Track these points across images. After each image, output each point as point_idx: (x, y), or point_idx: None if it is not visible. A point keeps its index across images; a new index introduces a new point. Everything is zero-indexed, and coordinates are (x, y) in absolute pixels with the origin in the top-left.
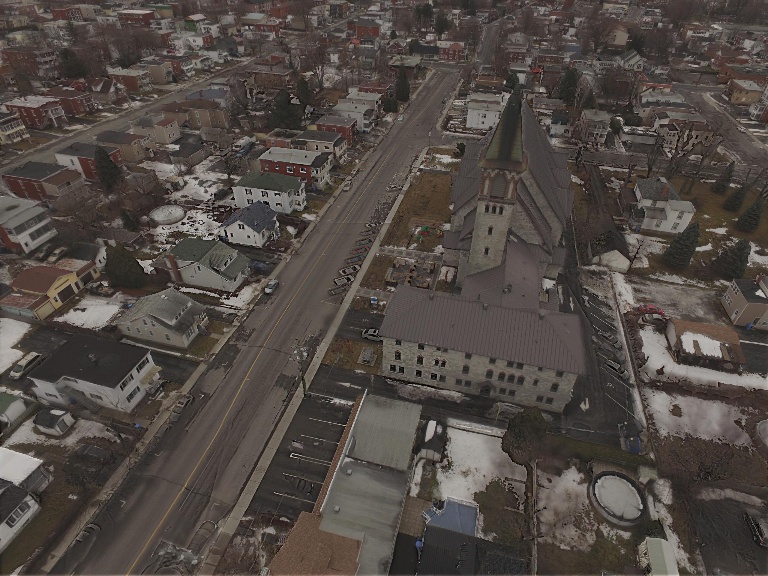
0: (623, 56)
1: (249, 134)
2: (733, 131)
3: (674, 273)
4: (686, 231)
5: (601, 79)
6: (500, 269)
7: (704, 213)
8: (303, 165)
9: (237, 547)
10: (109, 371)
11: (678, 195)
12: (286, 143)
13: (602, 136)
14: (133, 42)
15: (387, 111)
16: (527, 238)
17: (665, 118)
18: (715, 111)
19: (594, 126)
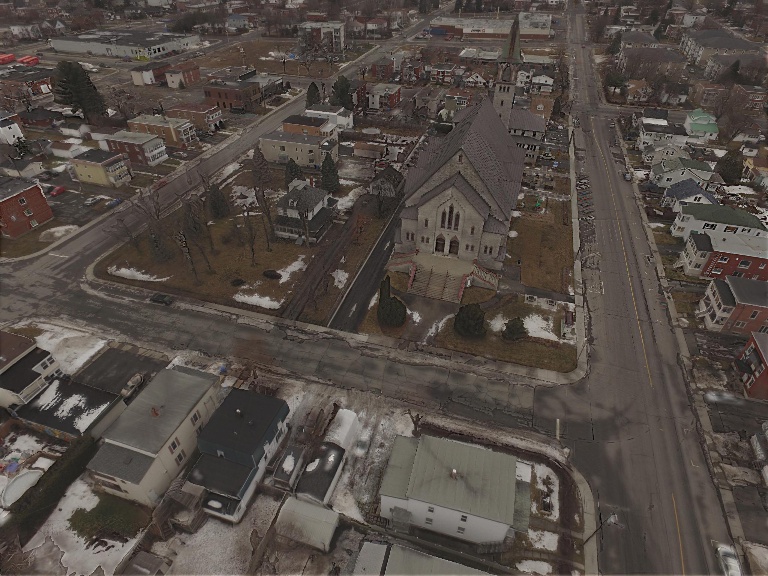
0: None
1: None
2: None
3: None
4: None
5: None
6: None
7: None
8: None
9: (565, 125)
10: (652, 127)
11: None
12: None
13: None
14: None
15: None
16: None
17: None
18: None
19: None
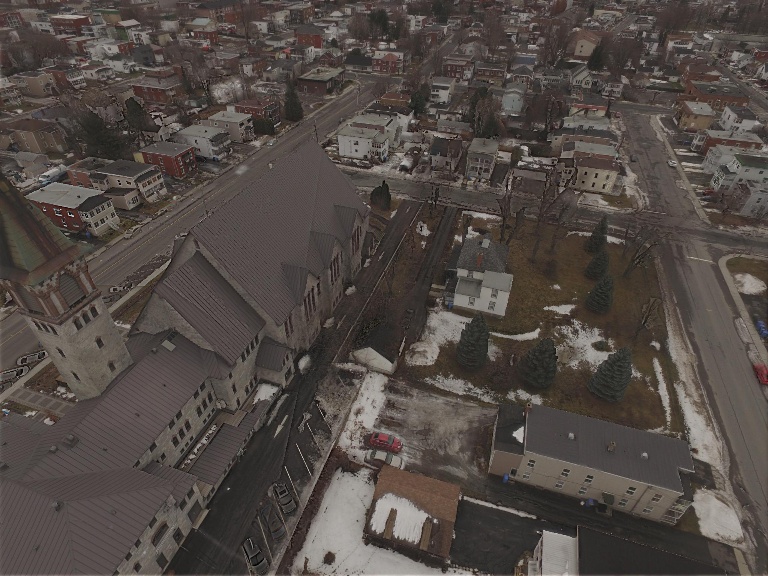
0: (573, 70)
1: (67, 162)
2: (661, 165)
3: (461, 376)
4: (470, 324)
5: (529, 98)
6: (96, 402)
7: (556, 282)
8: (68, 208)
9: None
10: None
11: (502, 264)
12: (87, 176)
13: (488, 171)
14: (29, 50)
15: (262, 133)
16: (198, 342)
17: (569, 150)
18: (654, 138)
19: (476, 159)
